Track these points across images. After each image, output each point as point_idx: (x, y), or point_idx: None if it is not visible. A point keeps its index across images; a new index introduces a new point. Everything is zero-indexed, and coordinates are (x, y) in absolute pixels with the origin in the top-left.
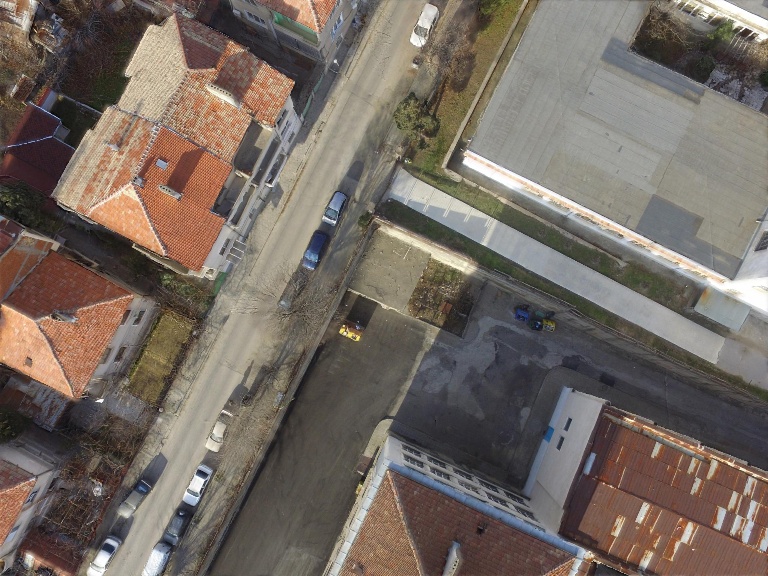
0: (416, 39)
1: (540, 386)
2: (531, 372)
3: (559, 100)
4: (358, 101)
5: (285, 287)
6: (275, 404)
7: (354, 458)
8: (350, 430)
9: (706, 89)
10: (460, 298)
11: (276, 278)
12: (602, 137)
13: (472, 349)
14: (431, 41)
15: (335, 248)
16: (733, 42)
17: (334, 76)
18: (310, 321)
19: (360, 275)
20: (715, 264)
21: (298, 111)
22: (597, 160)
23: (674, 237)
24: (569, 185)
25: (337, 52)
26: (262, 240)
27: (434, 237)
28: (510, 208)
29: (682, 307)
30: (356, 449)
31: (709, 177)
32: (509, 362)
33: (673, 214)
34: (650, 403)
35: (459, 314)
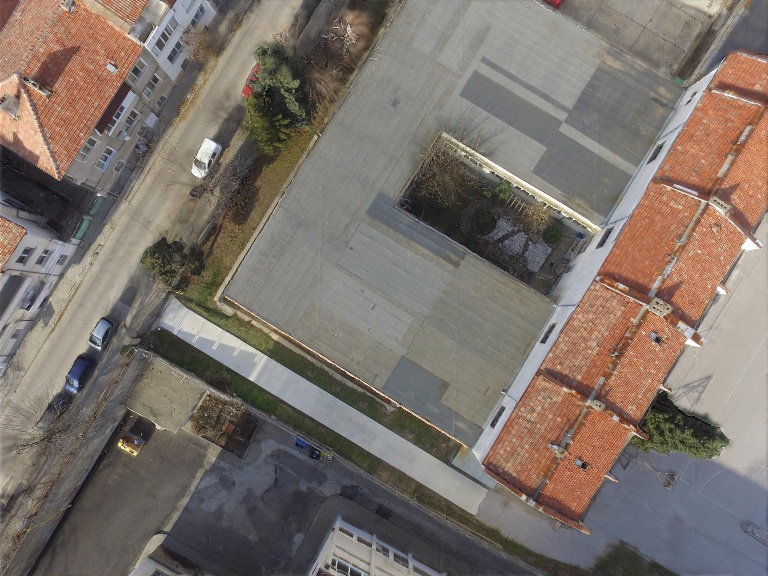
0: (196, 170)
1: (316, 513)
2: (309, 498)
3: (318, 253)
4: (137, 226)
5: (46, 408)
6: (20, 527)
7: (125, 570)
8: (123, 541)
9: (467, 253)
10: (243, 420)
11: (41, 397)
12: (357, 294)
13: (252, 471)
14: (213, 173)
15: (101, 372)
16: (509, 202)
17: (115, 199)
18: (61, 447)
19: (136, 394)
20: (457, 431)
21: (65, 238)
22: (350, 316)
23: (418, 401)
24: (320, 339)
25: (119, 176)
26: (30, 358)
27: (200, 369)
28: (281, 345)
29: (447, 456)
30: (128, 561)
31: (459, 343)
32: (288, 487)
33: (420, 377)
34: (423, 540)
35: (240, 436)
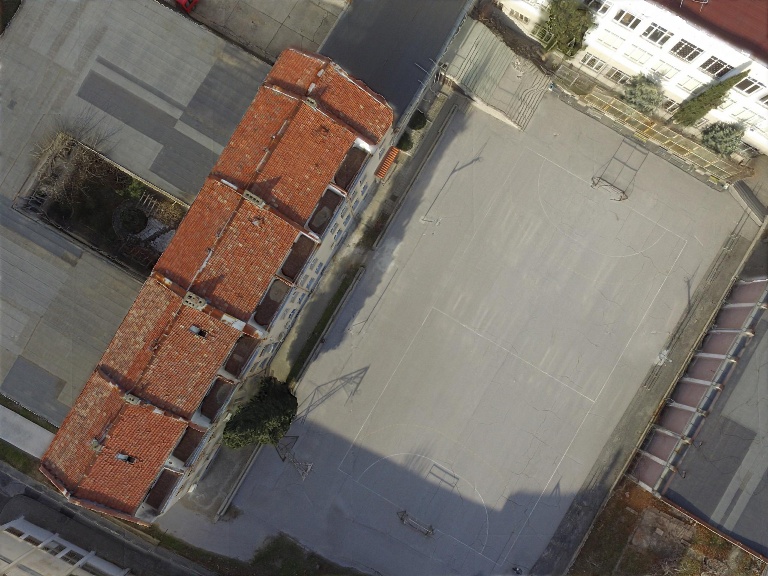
0: None
1: None
2: None
3: None
4: None
5: None
6: None
7: None
8: None
9: (85, 251)
10: None
11: None
12: None
13: None
14: None
15: None
16: (142, 199)
17: None
18: None
19: None
20: None
21: None
22: None
23: (36, 399)
24: None
25: None
26: None
27: None
28: None
29: None
30: None
31: (74, 341)
32: None
33: (36, 376)
34: (107, 536)
35: None
